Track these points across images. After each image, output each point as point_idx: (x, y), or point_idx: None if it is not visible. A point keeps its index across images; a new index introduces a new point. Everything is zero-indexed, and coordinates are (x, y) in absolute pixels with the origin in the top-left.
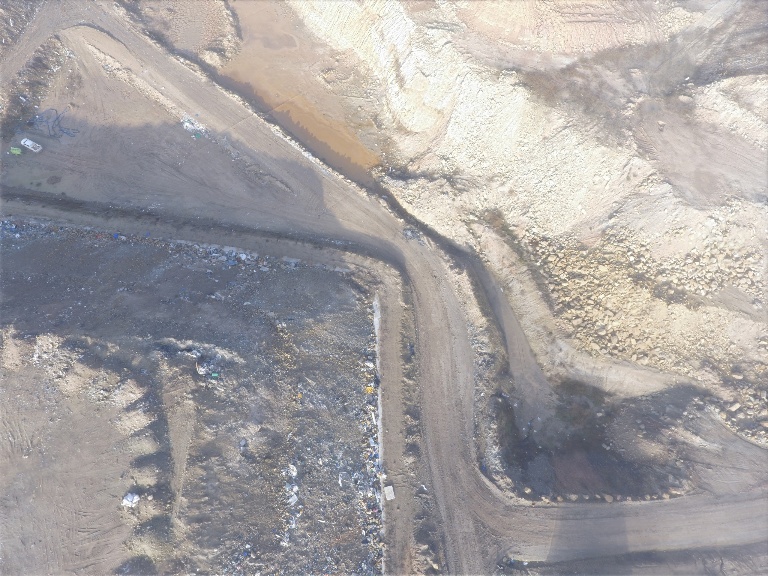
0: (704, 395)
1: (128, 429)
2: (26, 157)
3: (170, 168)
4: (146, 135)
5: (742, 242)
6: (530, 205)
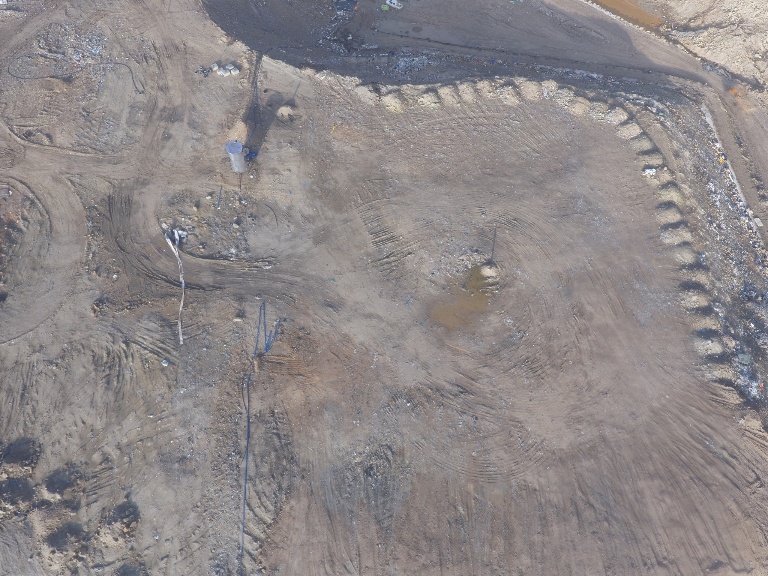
0: None
1: (627, 136)
2: (391, 13)
3: (502, 23)
4: (474, 0)
5: None
6: None
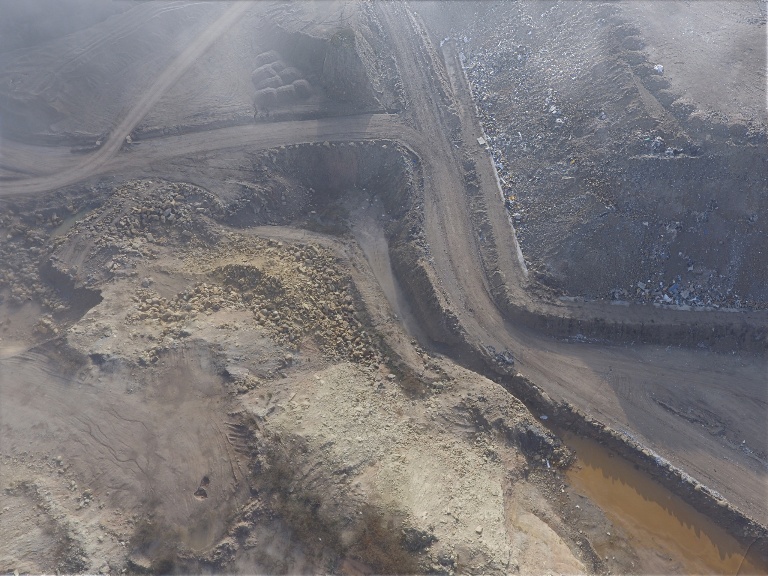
0: (223, 220)
1: (685, 99)
2: None
3: None
4: None
5: None
6: None
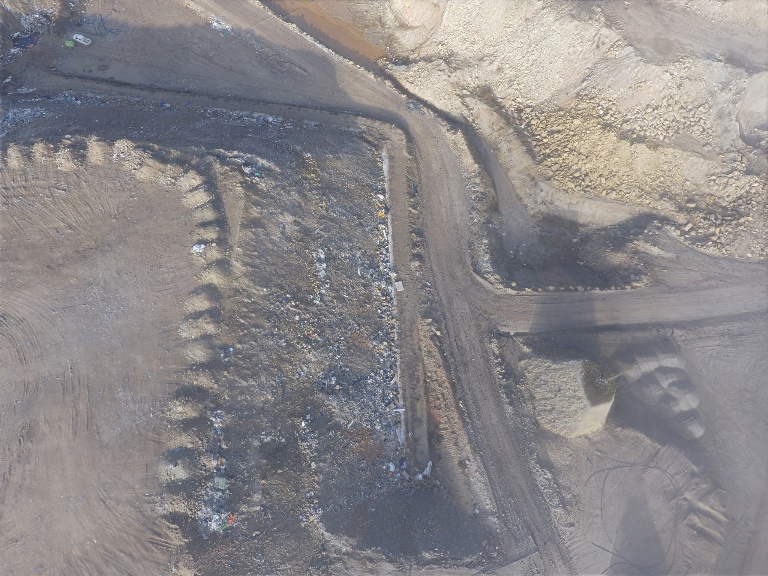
0: (663, 220)
1: (192, 204)
2: (78, 50)
3: (202, 58)
4: (180, 33)
5: (694, 95)
6: (515, 78)
